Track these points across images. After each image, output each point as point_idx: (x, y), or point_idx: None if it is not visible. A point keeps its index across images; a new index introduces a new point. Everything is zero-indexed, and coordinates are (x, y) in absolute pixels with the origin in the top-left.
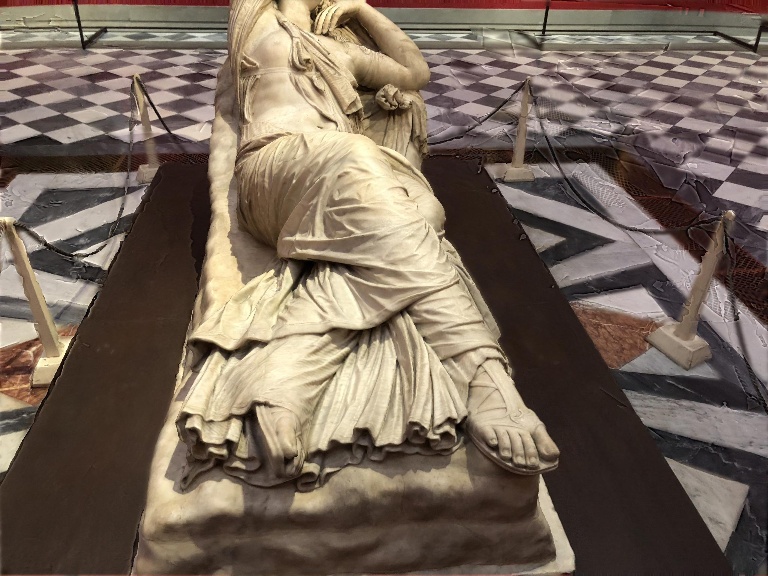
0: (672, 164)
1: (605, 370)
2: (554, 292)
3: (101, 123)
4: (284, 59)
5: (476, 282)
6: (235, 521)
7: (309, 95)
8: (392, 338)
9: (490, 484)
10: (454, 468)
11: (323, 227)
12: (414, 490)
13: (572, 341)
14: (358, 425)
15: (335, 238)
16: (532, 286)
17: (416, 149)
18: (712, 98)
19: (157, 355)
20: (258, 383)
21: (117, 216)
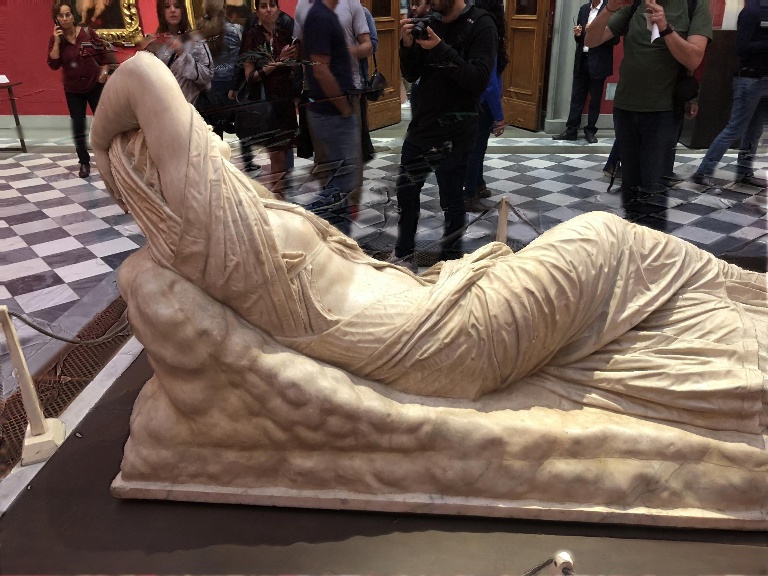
0: (358, 210)
1: None
2: None
3: None
4: (315, 233)
5: None
6: None
7: (355, 256)
8: None
9: None
10: None
11: None
12: None
13: None
14: None
15: None
16: None
17: None
18: (366, 153)
19: None
20: None
21: None
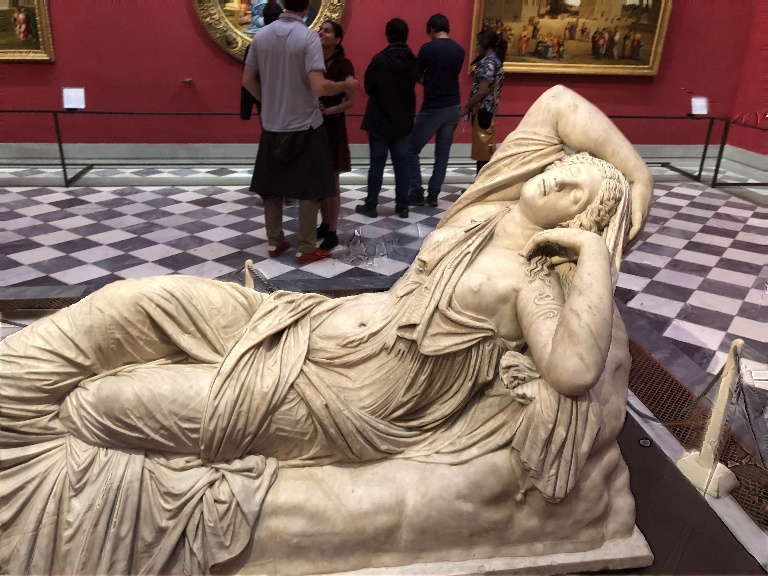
0: None
1: None
2: None
3: (699, 311)
4: None
5: None
6: None
7: None
8: None
9: None
10: None
11: None
12: None
13: None
14: None
15: None
16: None
17: (511, 465)
18: None
19: None
20: None
21: None
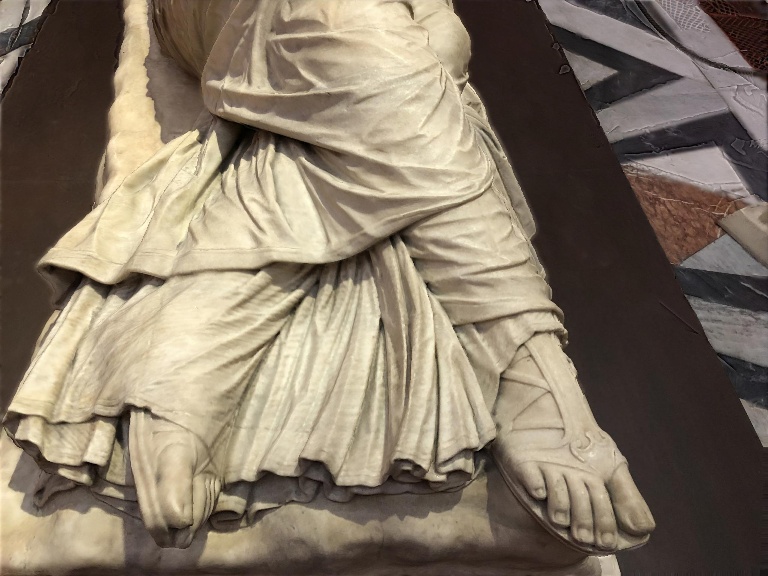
0: None
1: (670, 276)
2: (605, 155)
3: None
4: None
5: (500, 136)
6: (113, 572)
7: None
8: (374, 278)
9: (523, 540)
10: (466, 509)
11: (266, 69)
12: (399, 543)
13: (627, 230)
14: (306, 453)
15: (283, 92)
16: (575, 144)
17: None
18: None
19: (57, 235)
20: (136, 367)
21: (26, 18)
